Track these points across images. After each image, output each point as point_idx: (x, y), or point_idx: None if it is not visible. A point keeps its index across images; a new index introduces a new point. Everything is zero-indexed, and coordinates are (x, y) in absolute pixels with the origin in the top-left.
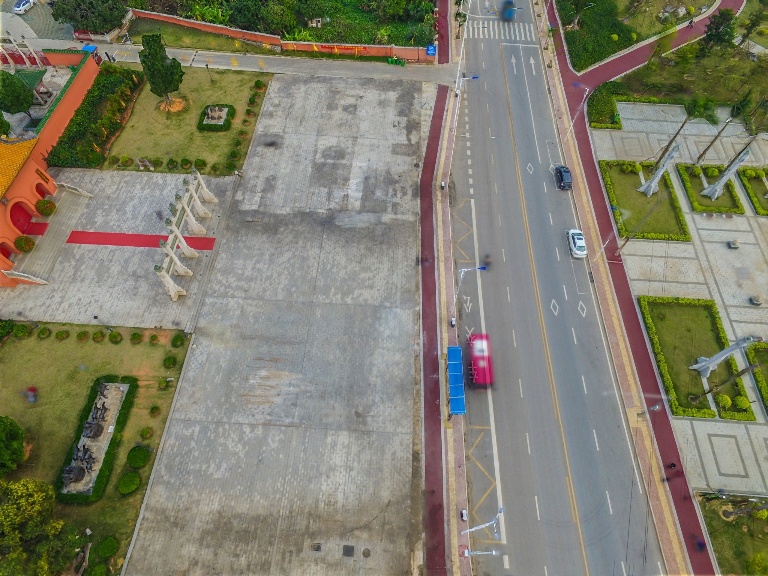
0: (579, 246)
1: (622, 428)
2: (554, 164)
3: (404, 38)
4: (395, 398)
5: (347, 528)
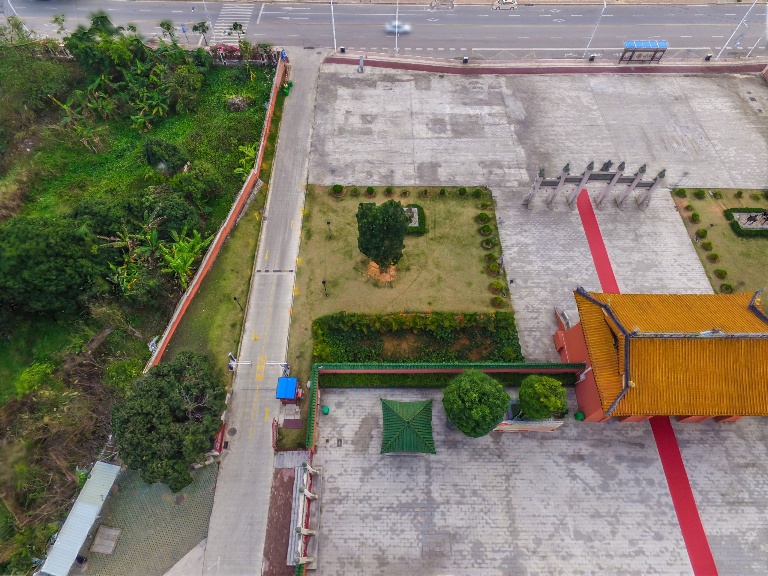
0: (512, 1)
1: (627, 7)
2: (426, 9)
3: (243, 82)
4: (657, 84)
5: (742, 100)
